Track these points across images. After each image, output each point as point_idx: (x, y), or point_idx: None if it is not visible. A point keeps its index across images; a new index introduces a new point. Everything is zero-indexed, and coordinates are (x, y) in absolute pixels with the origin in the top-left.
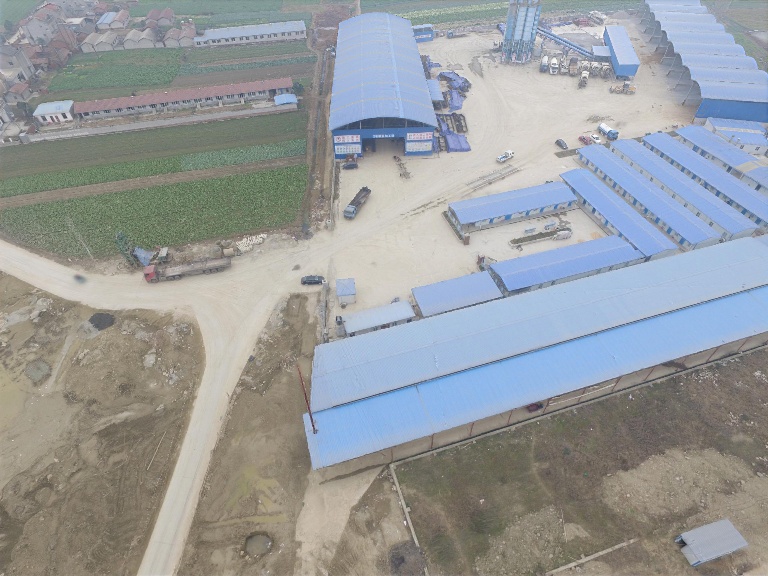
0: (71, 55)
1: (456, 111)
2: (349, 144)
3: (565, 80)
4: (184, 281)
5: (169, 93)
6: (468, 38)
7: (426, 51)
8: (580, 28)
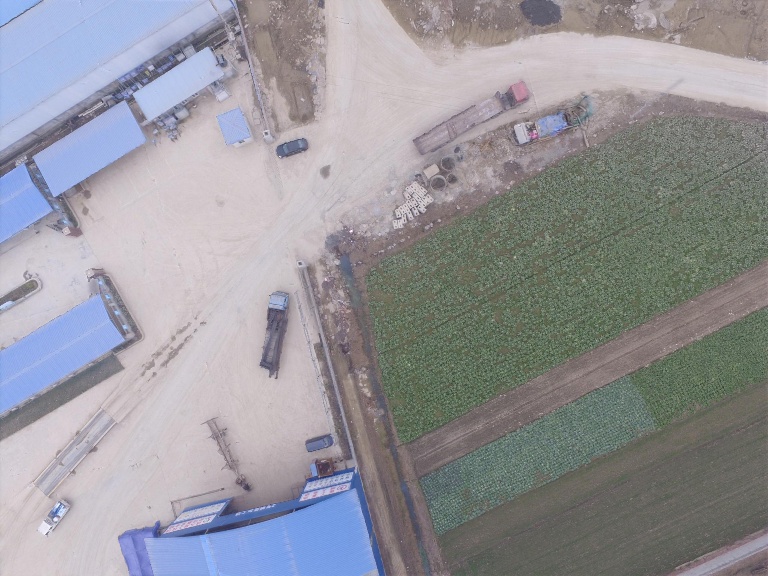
0: None
1: None
2: (325, 488)
3: None
4: None
5: None
6: None
7: None
8: None
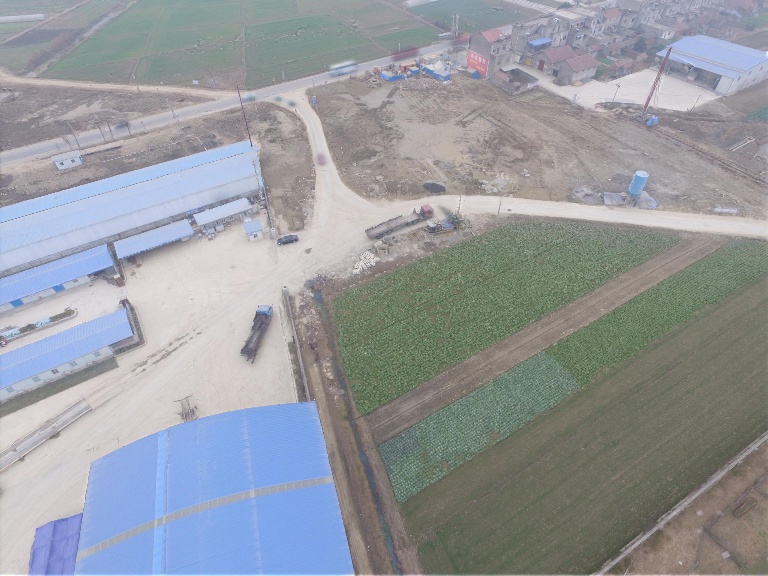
0: None
1: None
2: None
3: None
4: None
5: None
6: None
7: None
8: None
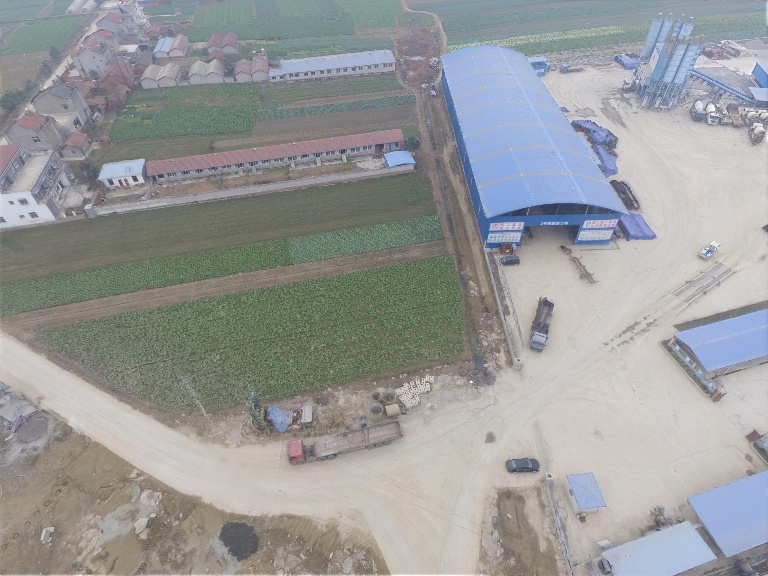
0: (130, 92)
1: (613, 176)
2: (507, 232)
3: (730, 133)
4: (340, 461)
5: (258, 149)
6: (586, 73)
7: None
8: (714, 61)
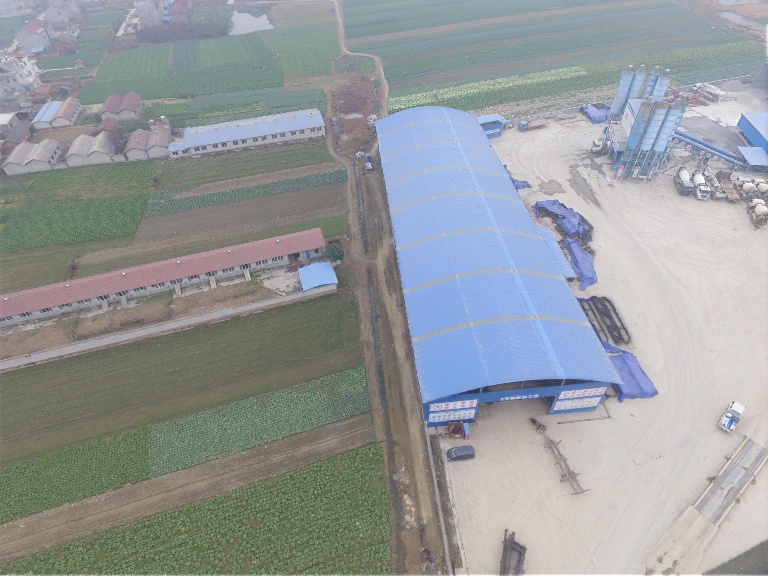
0: None
1: (591, 287)
2: (455, 410)
3: (725, 211)
4: None
5: (129, 273)
6: (548, 130)
7: (498, 156)
8: (690, 108)
